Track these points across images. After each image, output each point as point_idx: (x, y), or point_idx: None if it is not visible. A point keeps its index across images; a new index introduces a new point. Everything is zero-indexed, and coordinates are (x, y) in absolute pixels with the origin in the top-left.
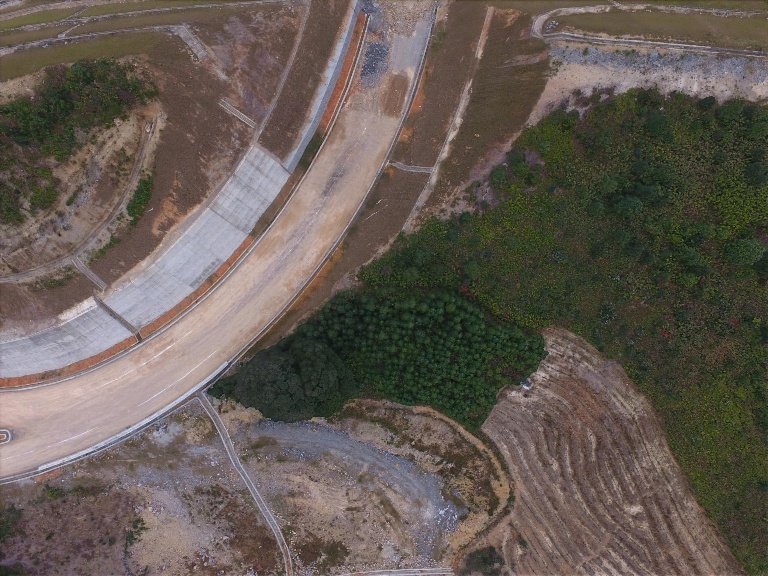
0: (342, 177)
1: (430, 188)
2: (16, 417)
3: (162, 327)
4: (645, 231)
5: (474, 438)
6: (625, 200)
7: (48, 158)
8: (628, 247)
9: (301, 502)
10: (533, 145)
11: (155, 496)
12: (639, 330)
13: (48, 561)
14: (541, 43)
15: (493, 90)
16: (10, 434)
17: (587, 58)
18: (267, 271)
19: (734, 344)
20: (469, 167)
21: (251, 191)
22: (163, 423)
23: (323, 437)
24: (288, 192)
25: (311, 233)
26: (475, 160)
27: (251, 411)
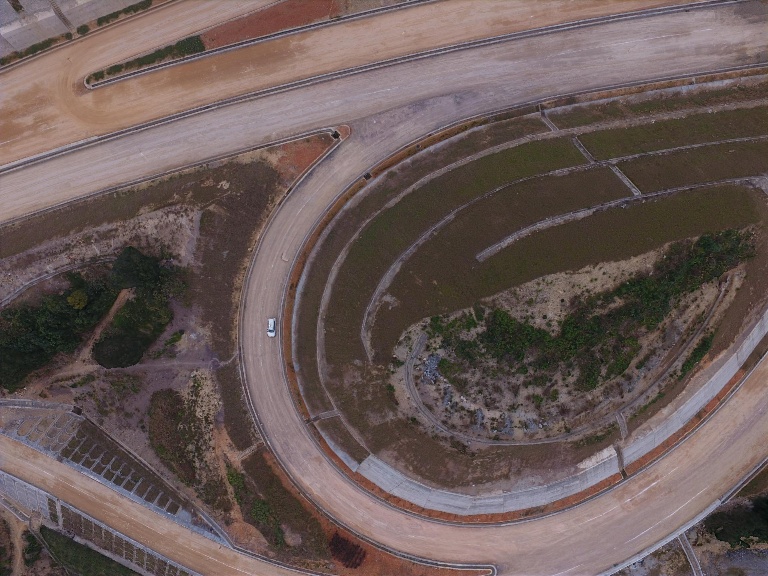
0: None
1: None
2: (499, 552)
3: (647, 463)
4: None
5: None
6: None
7: (640, 327)
8: None
9: None
10: None
11: None
12: None
13: None
14: None
15: None
16: (496, 569)
17: None
18: (758, 406)
19: None
20: None
21: (762, 328)
22: None
23: None
24: None
25: None
26: None
27: (722, 543)
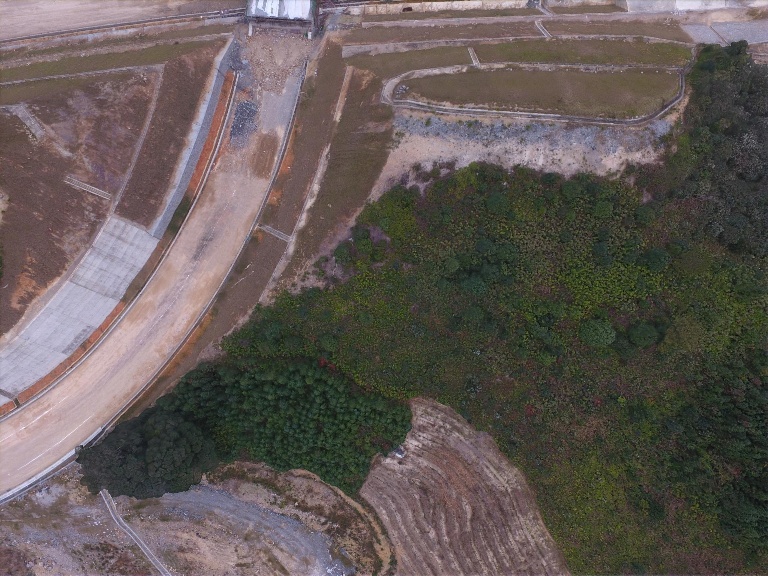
0: (212, 241)
1: (287, 258)
2: None
3: (39, 392)
4: None
5: (353, 502)
6: (469, 280)
7: None
8: (485, 322)
9: (191, 557)
10: (376, 221)
11: (45, 552)
12: (505, 404)
13: None
14: (388, 111)
15: (346, 157)
16: None
17: (429, 129)
18: (139, 337)
19: (603, 421)
20: (320, 239)
21: (115, 260)
22: (45, 485)
23: (206, 497)
24: (158, 257)
25: (182, 298)
26: (325, 233)
27: None
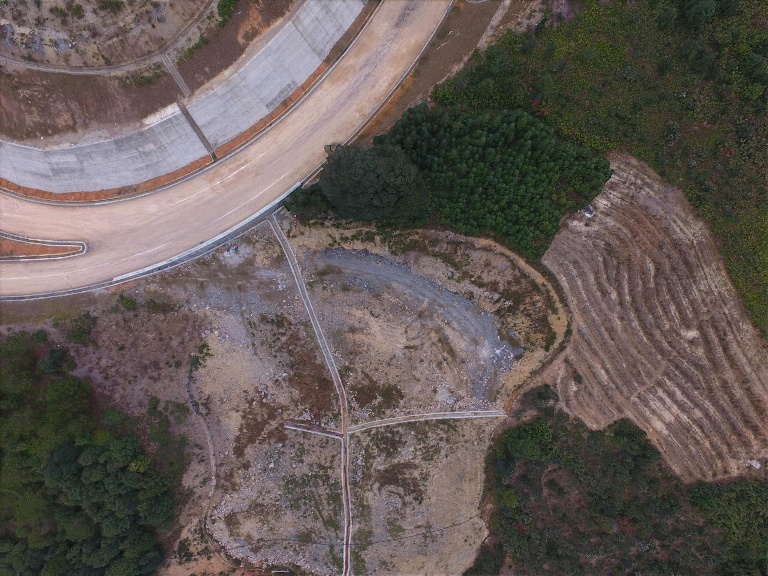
0: (414, 10)
1: (504, 9)
2: (92, 231)
3: (237, 148)
4: (713, 44)
5: (534, 271)
6: (698, 3)
7: None
8: (695, 62)
9: (361, 339)
10: None
11: (222, 321)
12: (701, 150)
13: (116, 378)
14: None
15: None
16: (86, 246)
17: None
18: (340, 97)
19: None
20: None
21: (329, 13)
22: (234, 244)
23: (386, 270)
24: (362, 22)
25: (383, 62)
26: None
27: (318, 238)
